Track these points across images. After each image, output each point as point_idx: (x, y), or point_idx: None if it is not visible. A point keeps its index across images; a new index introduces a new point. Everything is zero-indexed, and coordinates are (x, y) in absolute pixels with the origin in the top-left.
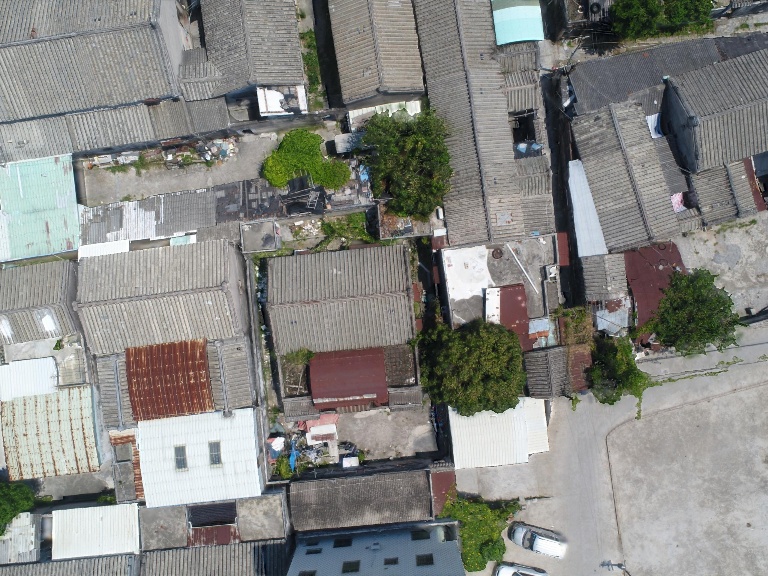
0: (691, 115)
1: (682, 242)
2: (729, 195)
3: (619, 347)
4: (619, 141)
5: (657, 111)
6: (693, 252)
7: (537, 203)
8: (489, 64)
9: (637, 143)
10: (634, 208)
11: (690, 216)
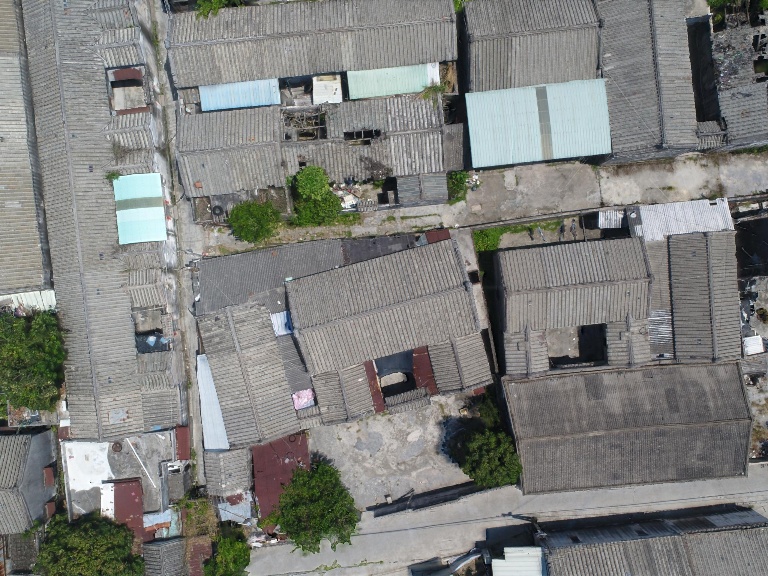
0: (295, 326)
1: (326, 428)
2: (342, 399)
3: (219, 550)
4: (234, 344)
5: (283, 310)
6: (336, 438)
7: (161, 397)
8: (110, 263)
9: (255, 344)
10: (248, 409)
11: (311, 415)
